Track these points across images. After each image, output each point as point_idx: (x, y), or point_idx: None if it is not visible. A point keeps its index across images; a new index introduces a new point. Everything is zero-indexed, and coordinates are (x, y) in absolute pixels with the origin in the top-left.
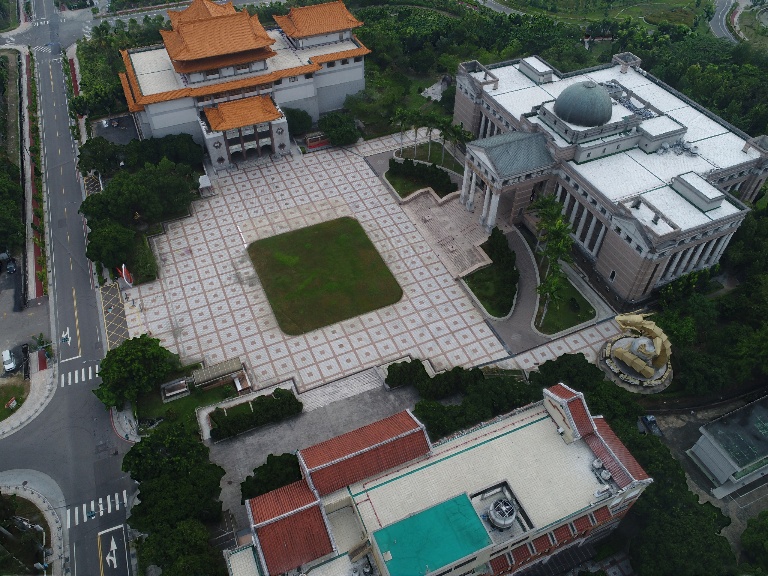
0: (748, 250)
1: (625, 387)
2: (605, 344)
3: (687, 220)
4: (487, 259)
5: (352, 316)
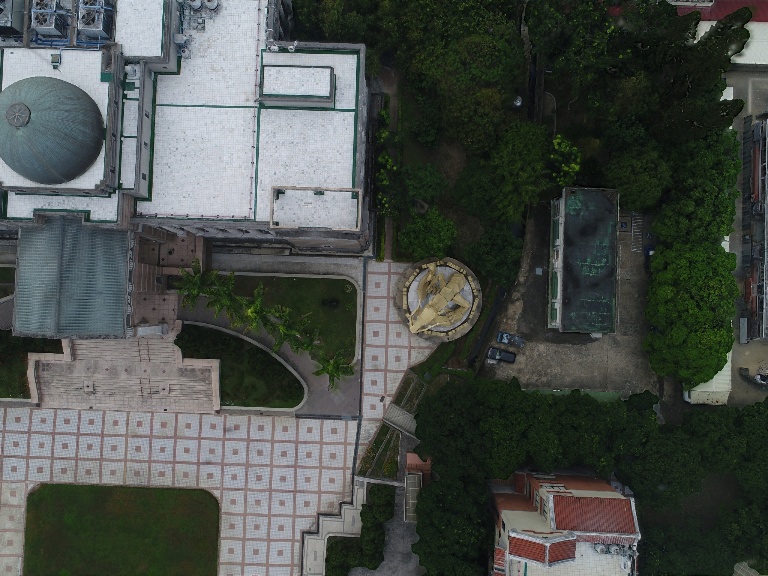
0: (373, 40)
1: (460, 334)
2: (400, 312)
3: (336, 145)
4: (210, 364)
5: (215, 571)
